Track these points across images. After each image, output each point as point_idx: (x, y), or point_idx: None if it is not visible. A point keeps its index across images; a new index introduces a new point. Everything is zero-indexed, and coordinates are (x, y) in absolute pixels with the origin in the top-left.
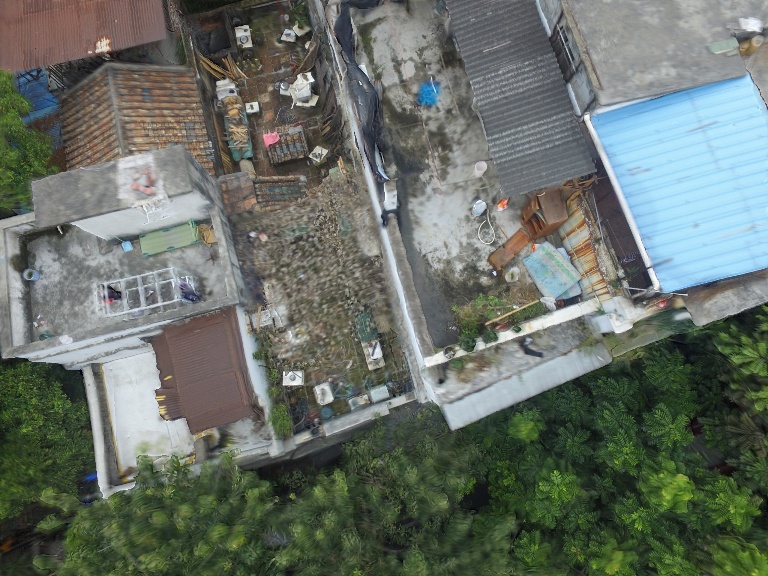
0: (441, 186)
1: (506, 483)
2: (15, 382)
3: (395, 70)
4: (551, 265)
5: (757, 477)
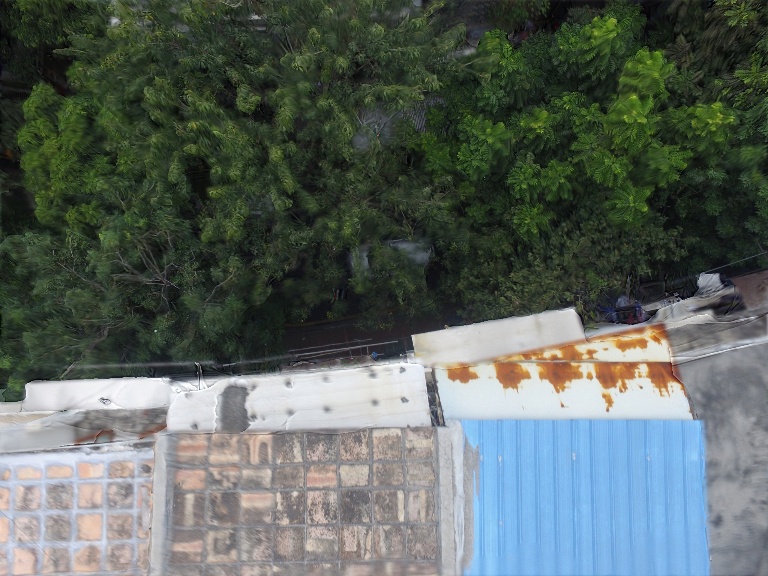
0: None
1: None
2: None
3: None
4: None
5: (676, 86)
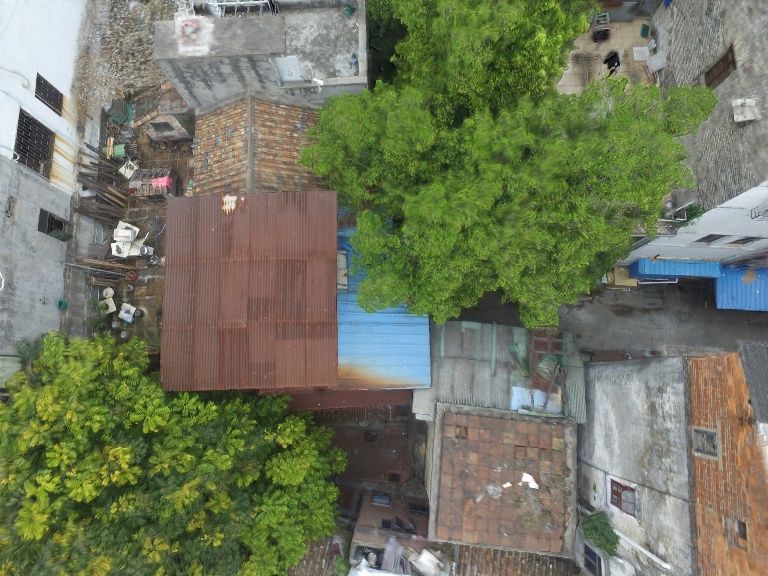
0: None
1: None
2: (390, 4)
3: None
4: None
5: None
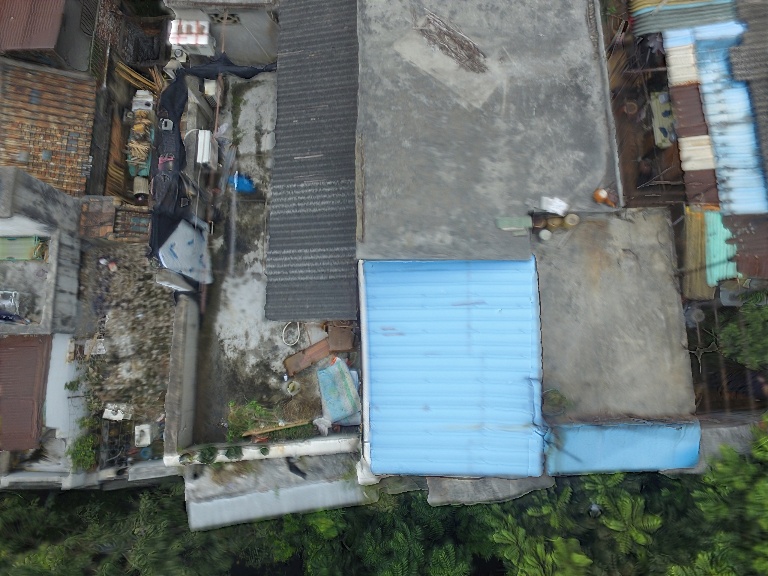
0: (262, 272)
1: (309, 569)
2: None
3: (256, 139)
4: (341, 386)
5: None
